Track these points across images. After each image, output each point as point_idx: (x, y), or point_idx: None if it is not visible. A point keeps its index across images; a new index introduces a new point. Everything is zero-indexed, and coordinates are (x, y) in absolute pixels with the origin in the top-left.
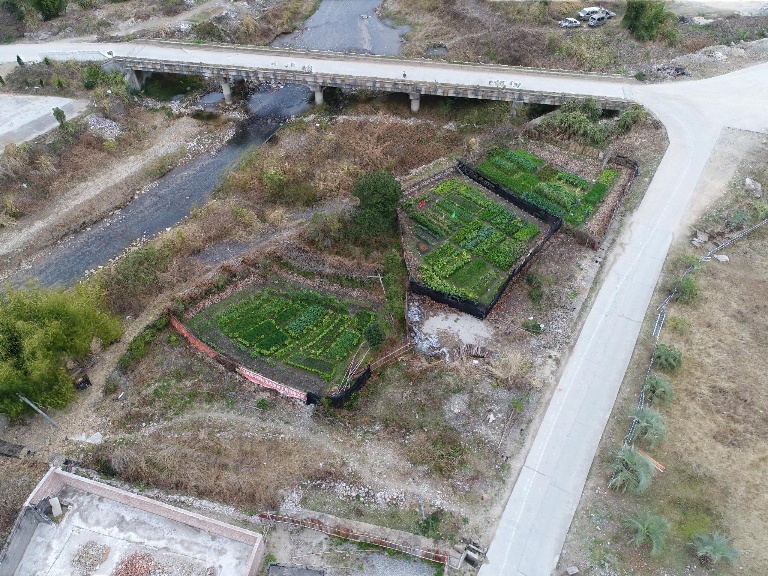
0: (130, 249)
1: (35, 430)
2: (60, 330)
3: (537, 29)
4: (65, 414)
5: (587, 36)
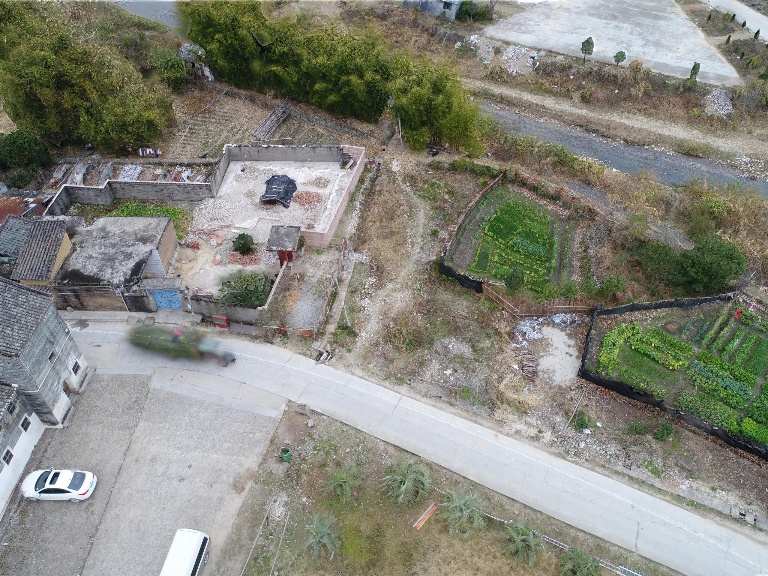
0: (583, 158)
1: (398, 147)
2: (441, 107)
3: None
4: (410, 153)
5: None
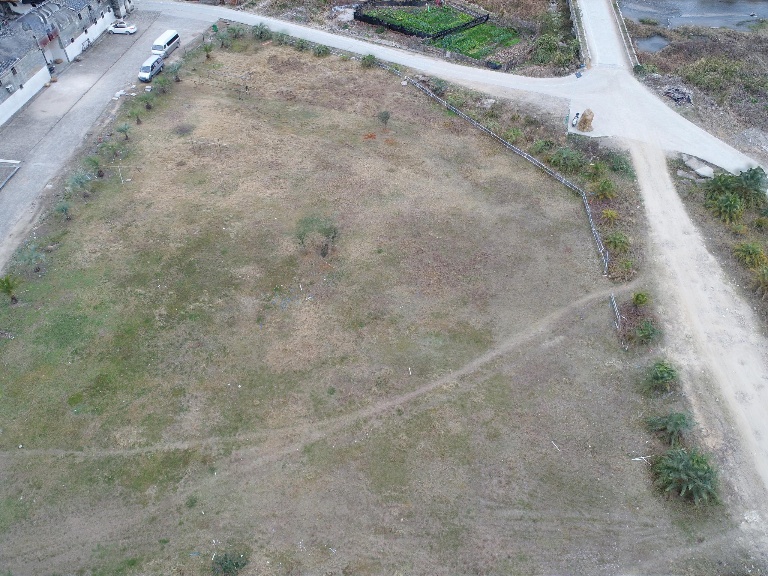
0: None
1: None
2: None
3: (767, 65)
4: None
5: (762, 81)
